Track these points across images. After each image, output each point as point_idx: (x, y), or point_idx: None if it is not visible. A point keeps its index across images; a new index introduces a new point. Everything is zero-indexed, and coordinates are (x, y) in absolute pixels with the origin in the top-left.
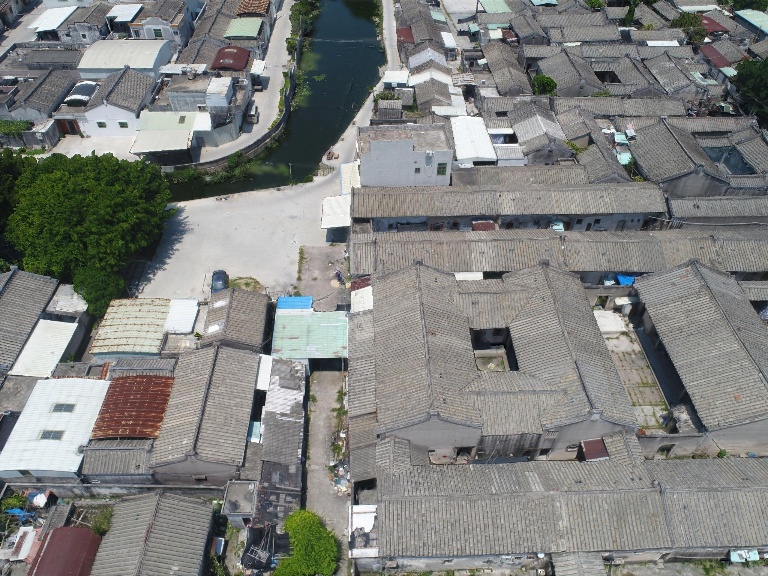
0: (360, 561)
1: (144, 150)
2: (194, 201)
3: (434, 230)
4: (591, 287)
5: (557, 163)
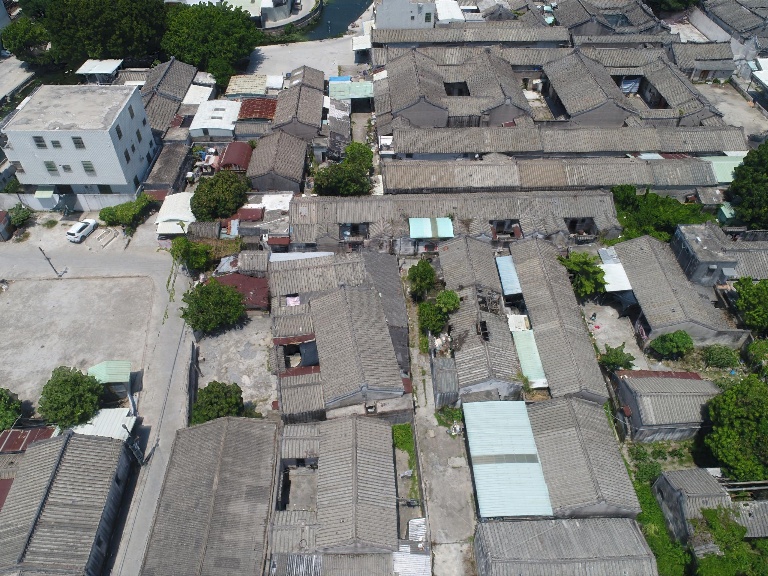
0: None
1: None
2: (266, 46)
3: None
4: (517, 71)
5: None
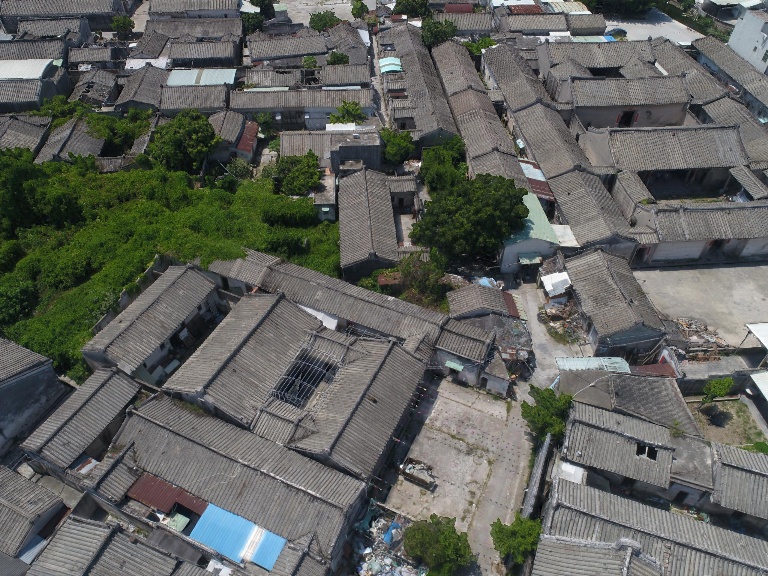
0: None
1: None
2: (680, 23)
3: None
4: (692, 115)
5: None
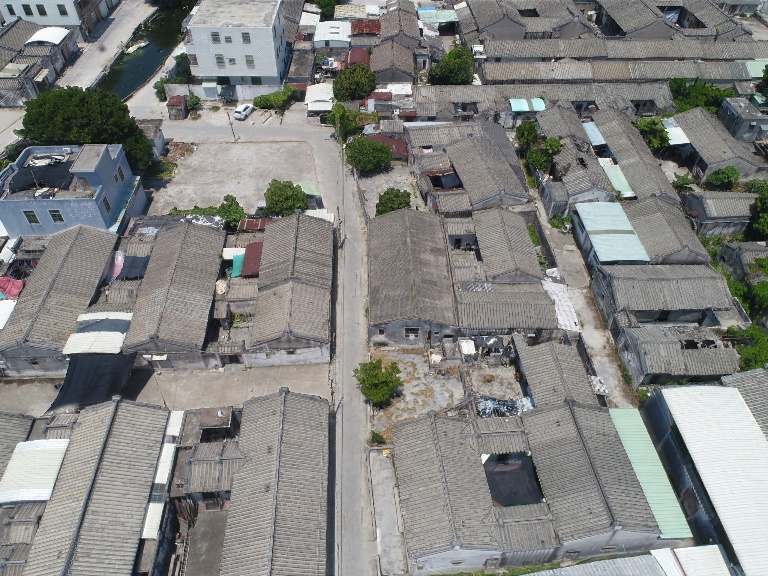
0: (477, 65)
1: None
2: None
3: None
4: (575, 3)
5: None
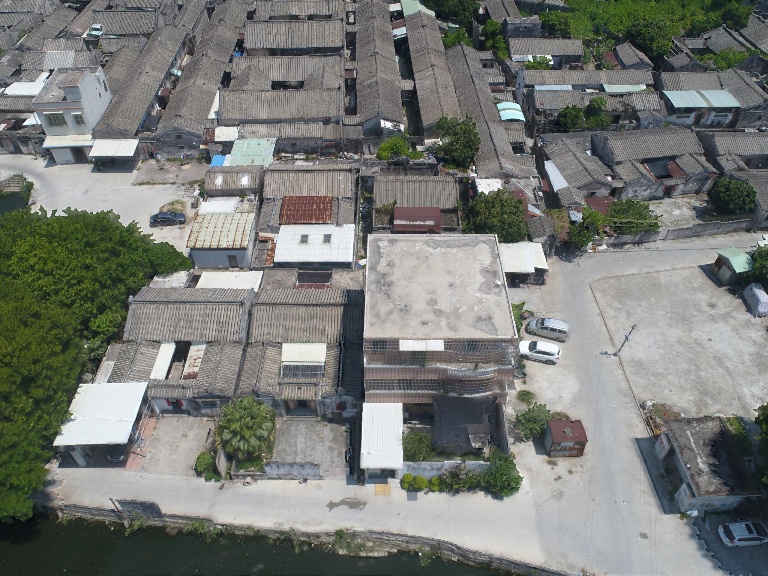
0: None
1: None
2: None
3: None
4: None
5: (103, 62)
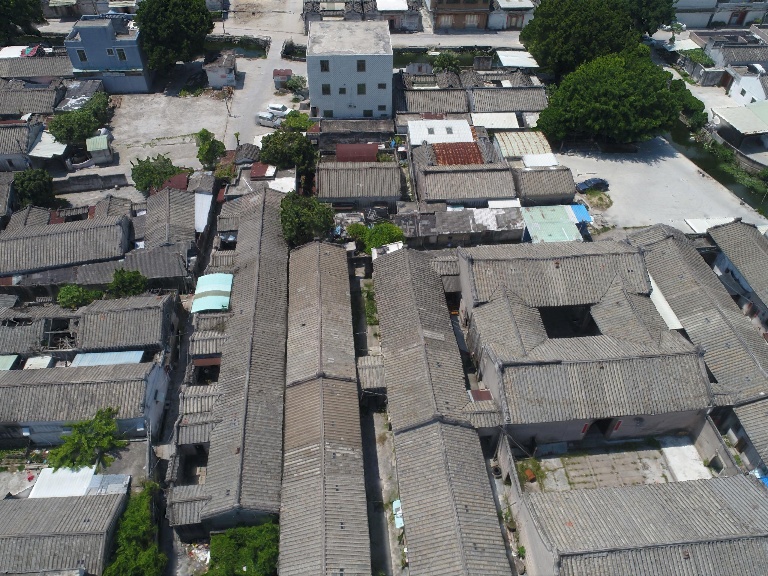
0: None
1: (720, 114)
2: (688, 160)
3: (752, 311)
4: (717, 432)
5: None
